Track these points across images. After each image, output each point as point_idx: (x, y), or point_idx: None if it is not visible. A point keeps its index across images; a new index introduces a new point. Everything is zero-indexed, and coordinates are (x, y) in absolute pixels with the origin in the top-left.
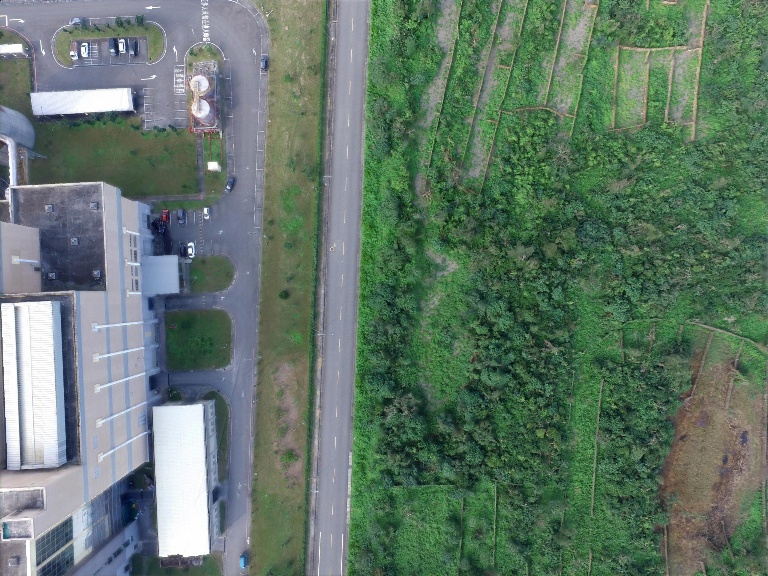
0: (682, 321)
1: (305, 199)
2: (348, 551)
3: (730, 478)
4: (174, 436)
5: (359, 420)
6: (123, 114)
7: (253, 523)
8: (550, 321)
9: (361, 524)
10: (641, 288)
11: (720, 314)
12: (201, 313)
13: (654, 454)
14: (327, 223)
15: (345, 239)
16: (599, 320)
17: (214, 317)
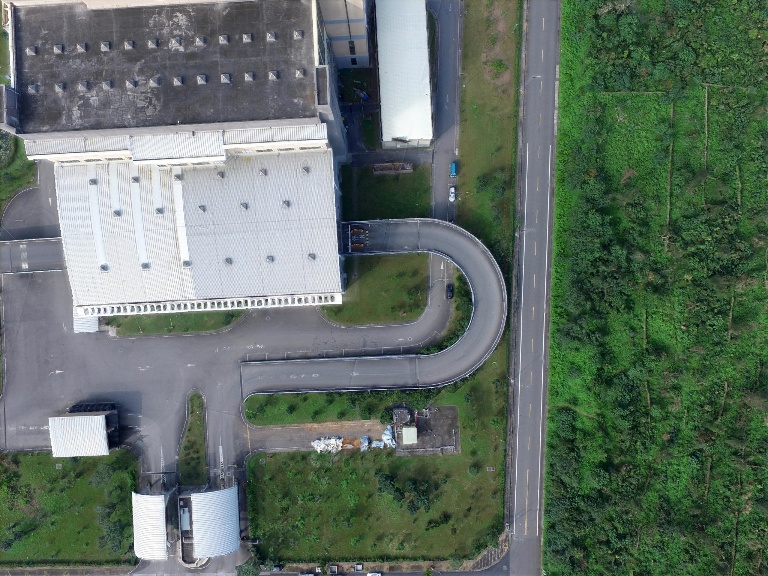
0: None
1: None
2: (557, 160)
3: None
4: (398, 21)
5: (567, 31)
6: None
7: (462, 134)
8: None
9: (569, 134)
10: None
11: None
12: None
13: None
14: None
15: None
16: None
17: None
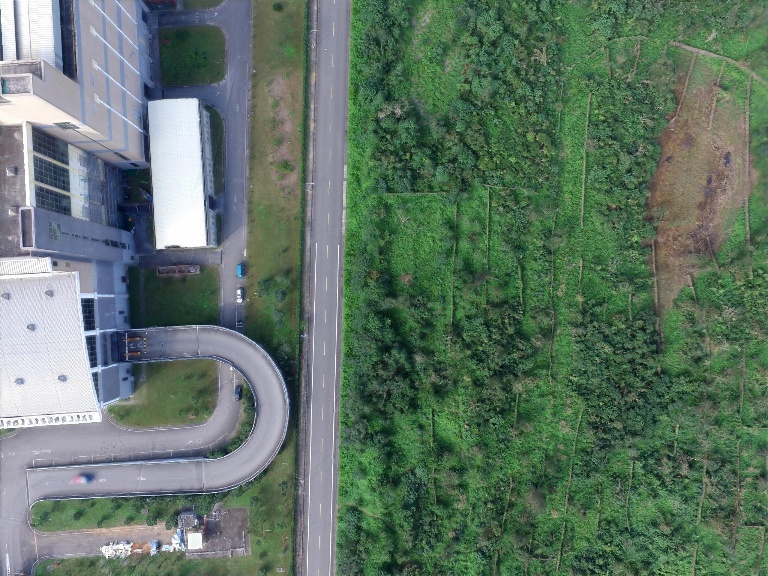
0: (666, 42)
1: None
2: (344, 260)
3: (714, 197)
4: (170, 128)
5: (353, 132)
6: None
7: (249, 234)
8: (538, 32)
9: (357, 234)
10: (626, 4)
11: (702, 36)
12: (195, 29)
13: (641, 167)
14: None
15: None
16: (586, 38)
17: (208, 33)
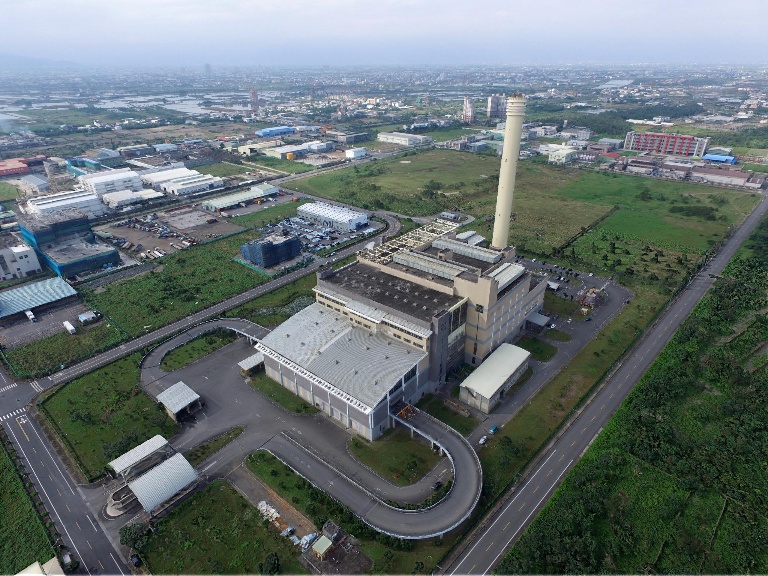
0: None
1: (627, 337)
2: None
3: None
4: (508, 353)
5: (617, 416)
6: (549, 290)
7: (513, 420)
8: None
9: (591, 461)
10: None
11: None
12: None
13: None
14: (636, 348)
15: (644, 357)
16: None
17: (549, 346)
